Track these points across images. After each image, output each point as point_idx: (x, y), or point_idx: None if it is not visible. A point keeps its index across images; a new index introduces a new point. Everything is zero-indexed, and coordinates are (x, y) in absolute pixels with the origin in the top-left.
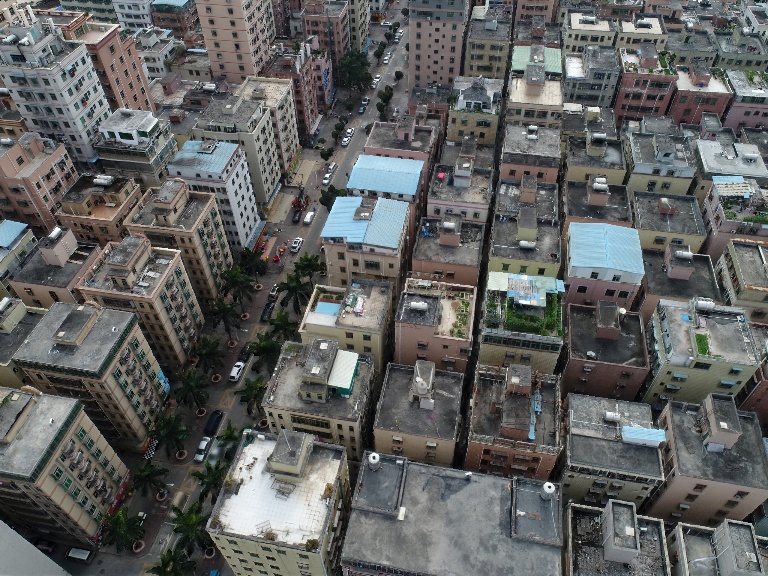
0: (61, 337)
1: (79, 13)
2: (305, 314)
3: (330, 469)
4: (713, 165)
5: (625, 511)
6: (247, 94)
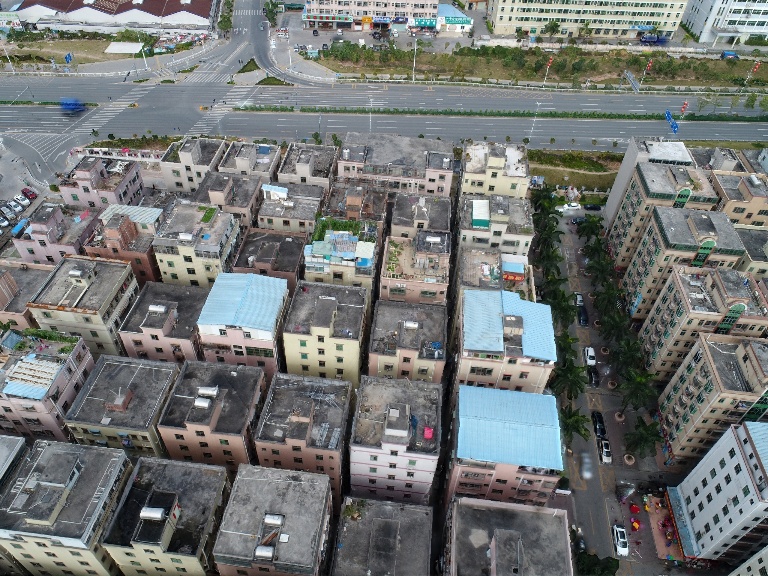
0: (702, 215)
1: None
2: None
3: (471, 168)
4: (3, 451)
5: (302, 162)
6: None
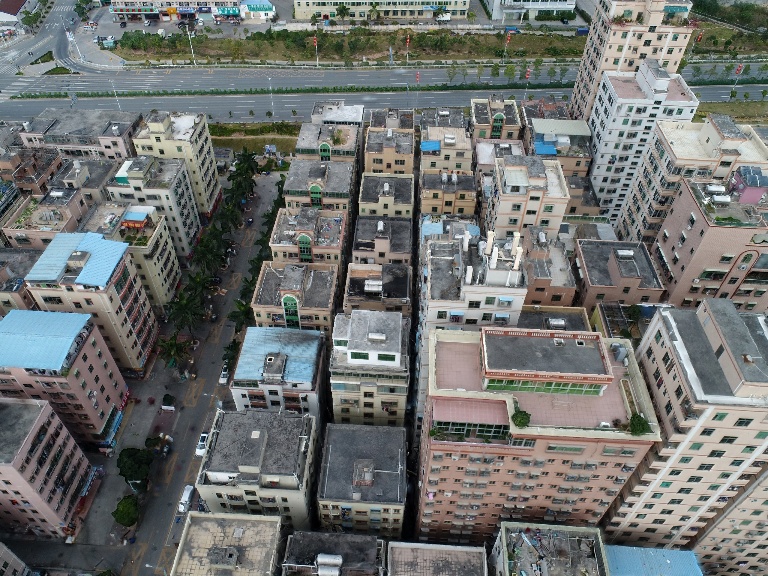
0: (322, 164)
1: (496, 369)
2: (159, 226)
3: (143, 135)
4: None
5: None
6: (253, 569)
